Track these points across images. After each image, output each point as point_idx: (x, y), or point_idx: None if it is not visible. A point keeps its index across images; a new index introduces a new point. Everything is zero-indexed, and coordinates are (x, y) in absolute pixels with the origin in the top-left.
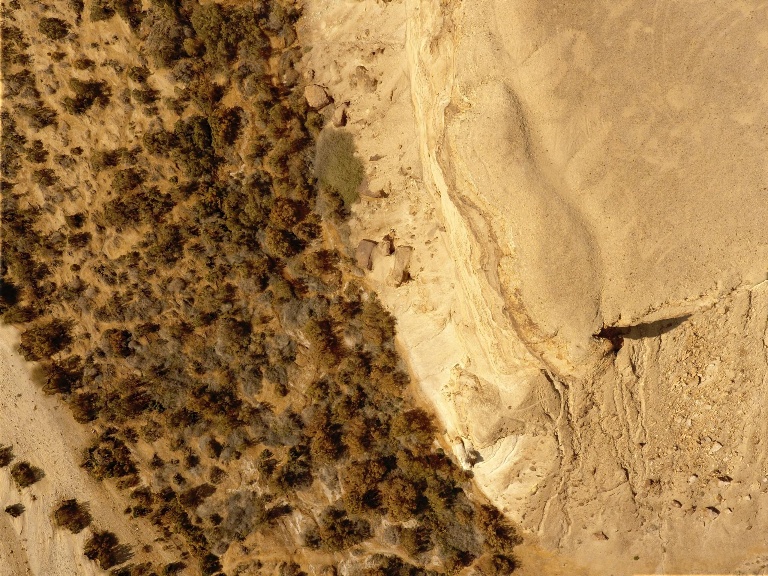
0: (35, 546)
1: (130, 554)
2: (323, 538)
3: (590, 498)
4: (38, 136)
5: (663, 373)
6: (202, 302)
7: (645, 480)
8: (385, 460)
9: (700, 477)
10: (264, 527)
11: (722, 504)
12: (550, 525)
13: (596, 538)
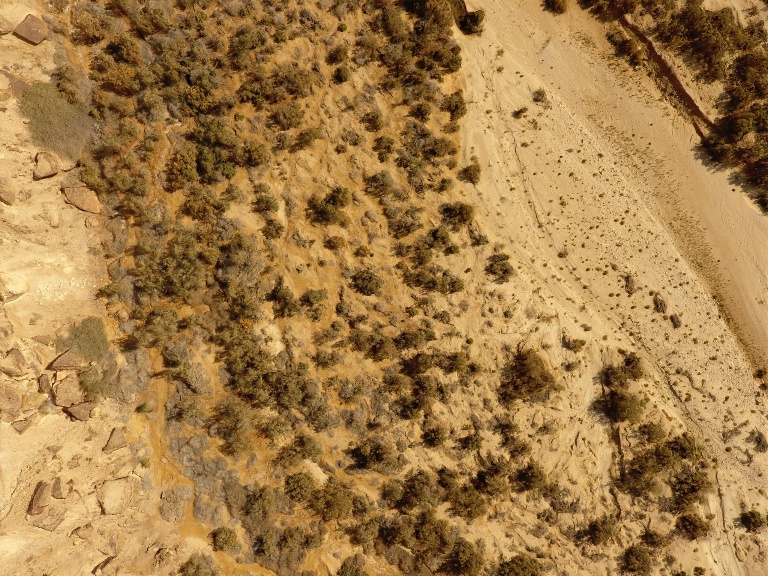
0: None
1: None
2: None
3: None
4: (383, 167)
5: None
6: None
7: None
8: None
9: None
10: None
11: None
12: None
13: None
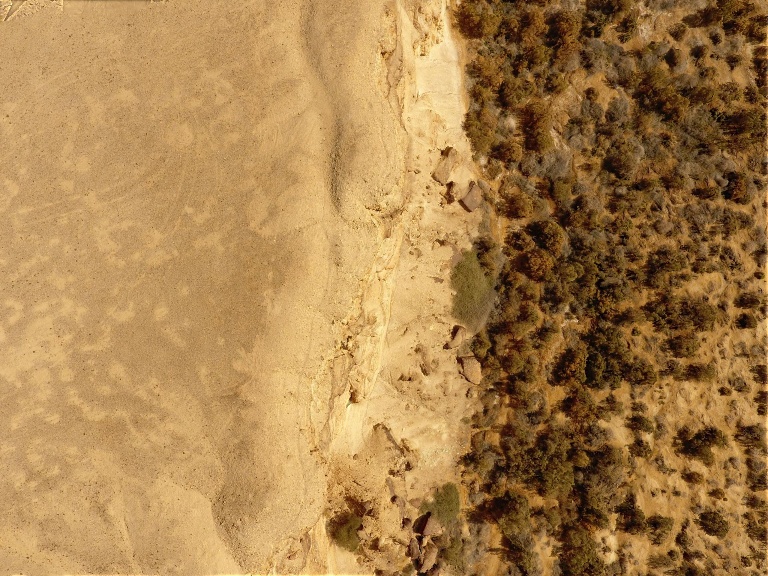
0: None
1: None
2: None
3: None
4: (760, 420)
5: None
6: (643, 203)
7: None
8: None
9: None
10: None
11: None
12: None
13: None
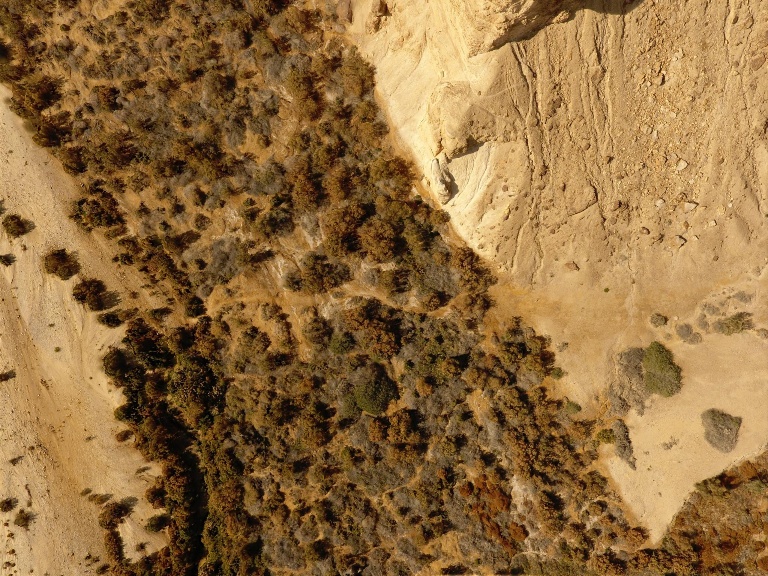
0: (25, 293)
1: (117, 300)
2: (304, 277)
3: (561, 222)
4: None
5: (628, 68)
6: (188, 59)
7: (614, 202)
8: (364, 206)
9: (667, 202)
10: (247, 270)
11: (689, 232)
12: (523, 259)
13: (567, 270)
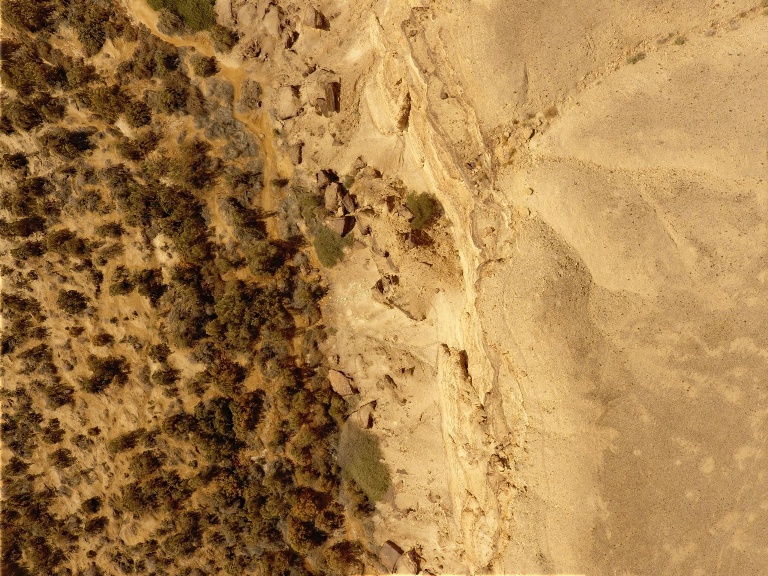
0: None
1: None
2: None
3: None
4: (55, 414)
5: None
6: None
7: None
8: None
9: None
10: None
11: None
12: None
13: None
